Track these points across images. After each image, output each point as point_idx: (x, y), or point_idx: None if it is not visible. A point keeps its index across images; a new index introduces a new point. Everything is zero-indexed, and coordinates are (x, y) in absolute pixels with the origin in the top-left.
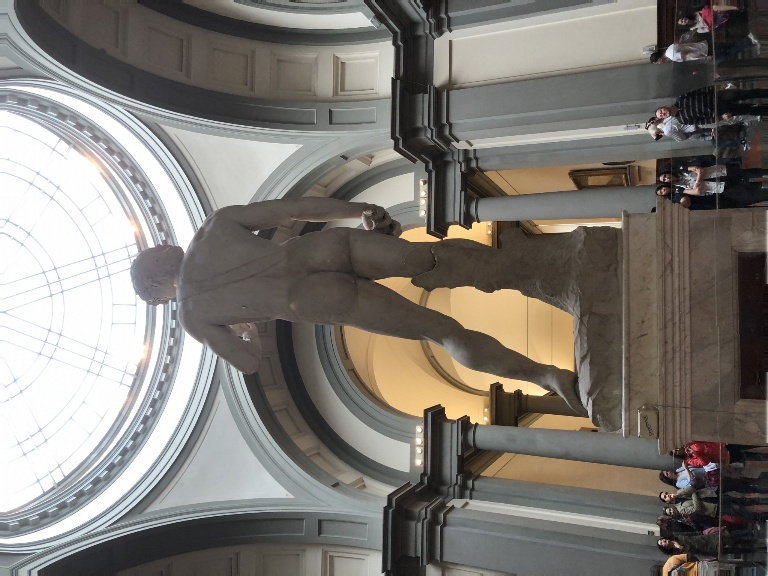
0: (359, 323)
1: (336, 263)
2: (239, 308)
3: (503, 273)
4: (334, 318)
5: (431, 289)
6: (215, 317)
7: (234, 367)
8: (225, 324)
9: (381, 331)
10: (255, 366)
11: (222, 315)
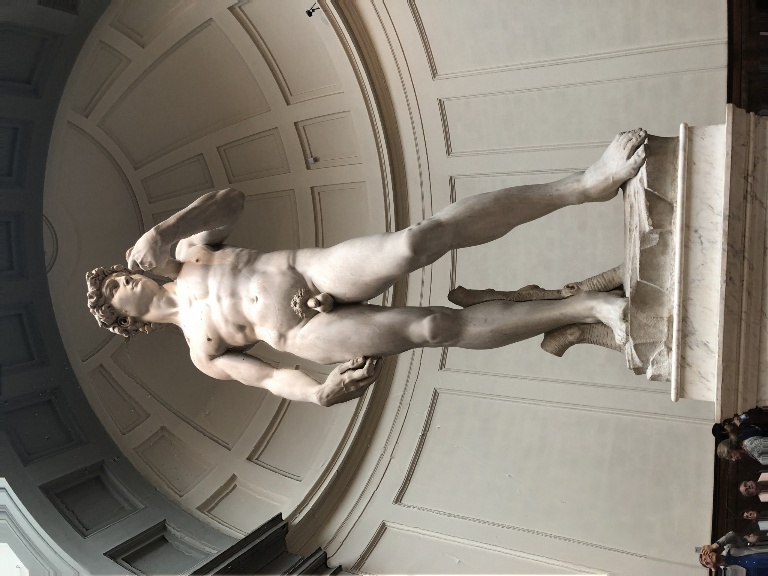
0: None
1: None
2: None
3: None
4: None
5: None
6: None
7: None
8: None
9: None
10: None
11: None
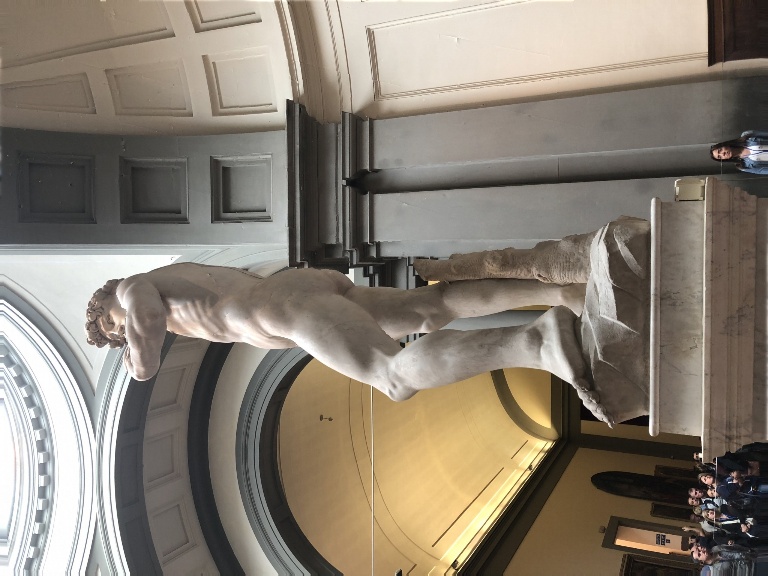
0: (315, 309)
1: (335, 278)
2: (203, 274)
3: (522, 250)
4: (293, 298)
5: (429, 274)
6: (169, 277)
7: (131, 304)
8: (167, 290)
9: (331, 325)
10: (155, 310)
11: (178, 276)
